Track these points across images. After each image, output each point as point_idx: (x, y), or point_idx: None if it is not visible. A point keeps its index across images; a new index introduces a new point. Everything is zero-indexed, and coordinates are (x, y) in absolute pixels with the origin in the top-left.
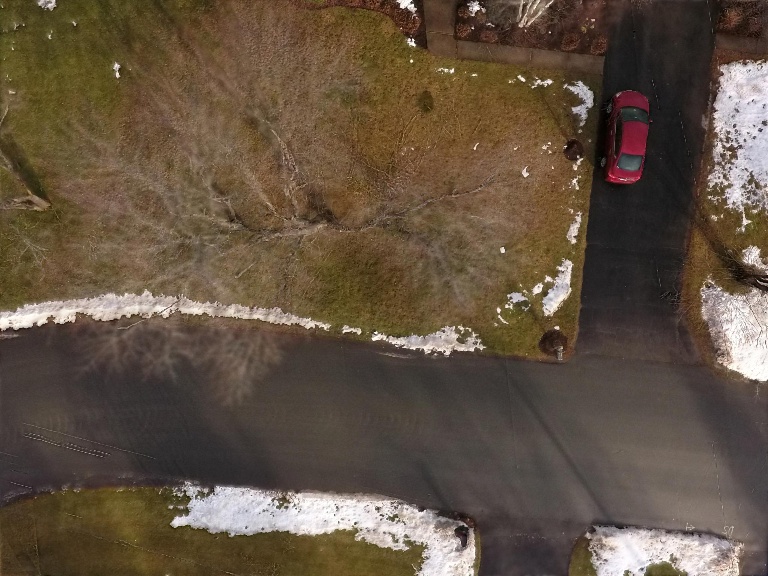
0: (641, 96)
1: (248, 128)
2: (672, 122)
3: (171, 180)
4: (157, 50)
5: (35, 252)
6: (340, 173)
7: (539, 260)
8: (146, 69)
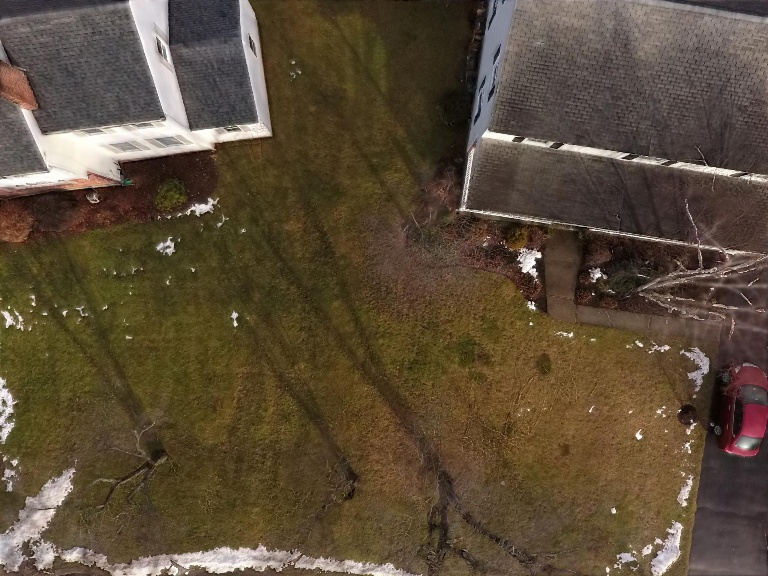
0: (760, 372)
1: (365, 384)
2: None
3: (288, 434)
4: (275, 300)
5: (180, 569)
6: (456, 432)
7: (649, 522)
8: (264, 319)
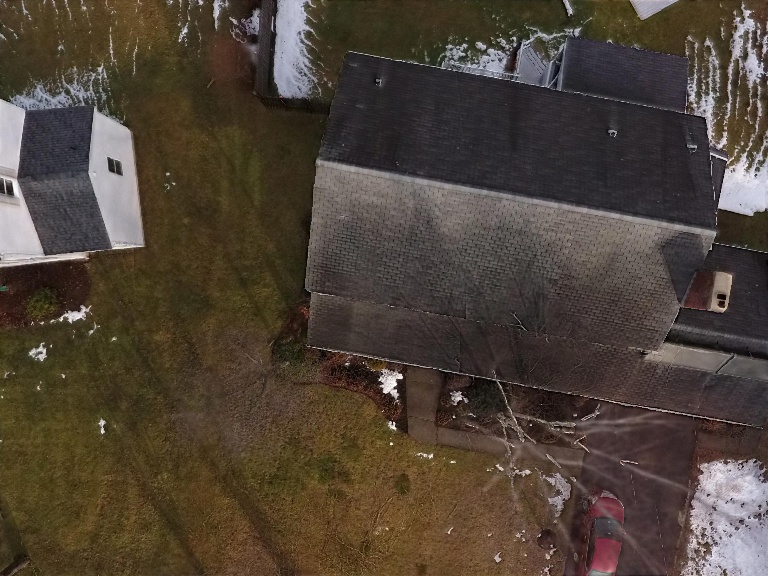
0: (617, 503)
1: (226, 497)
2: (648, 517)
3: (148, 543)
4: (142, 409)
5: None
6: (314, 549)
7: None
8: (130, 427)
